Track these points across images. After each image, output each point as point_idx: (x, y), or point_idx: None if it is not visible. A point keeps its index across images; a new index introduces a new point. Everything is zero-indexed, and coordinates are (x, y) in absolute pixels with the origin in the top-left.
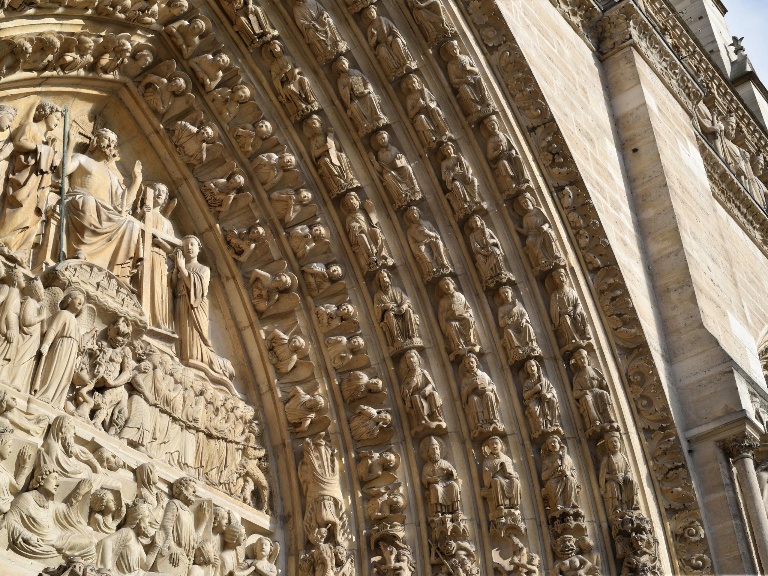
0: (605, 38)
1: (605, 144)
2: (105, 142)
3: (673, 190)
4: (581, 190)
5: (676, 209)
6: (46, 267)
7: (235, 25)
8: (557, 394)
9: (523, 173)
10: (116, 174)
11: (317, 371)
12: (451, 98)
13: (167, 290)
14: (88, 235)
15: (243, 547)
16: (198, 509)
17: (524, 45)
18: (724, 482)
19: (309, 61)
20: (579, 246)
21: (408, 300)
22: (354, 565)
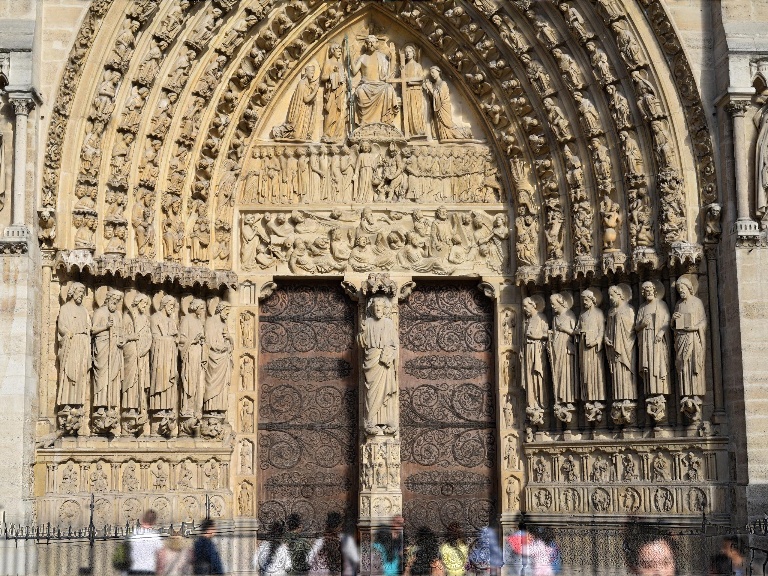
0: None
1: None
2: (370, 44)
3: None
4: None
5: None
6: None
7: None
8: (630, 100)
9: None
10: (388, 50)
11: (511, 119)
12: None
13: (423, 107)
14: (364, 110)
15: (490, 223)
16: (452, 219)
17: None
18: (725, 135)
19: None
20: None
21: (540, 68)
22: (539, 222)
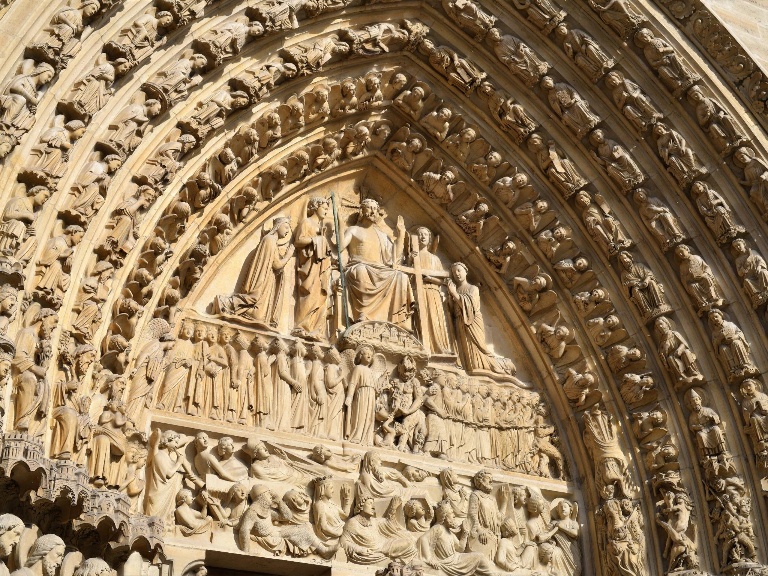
0: None
1: None
2: (369, 211)
3: None
4: None
5: None
6: (339, 334)
7: (449, 80)
8: None
9: (734, 131)
10: (386, 230)
11: (585, 351)
12: (654, 80)
13: (444, 317)
14: (366, 299)
15: (547, 512)
16: (498, 493)
17: (716, 5)
18: None
19: (520, 88)
20: None
21: (650, 273)
22: (641, 512)
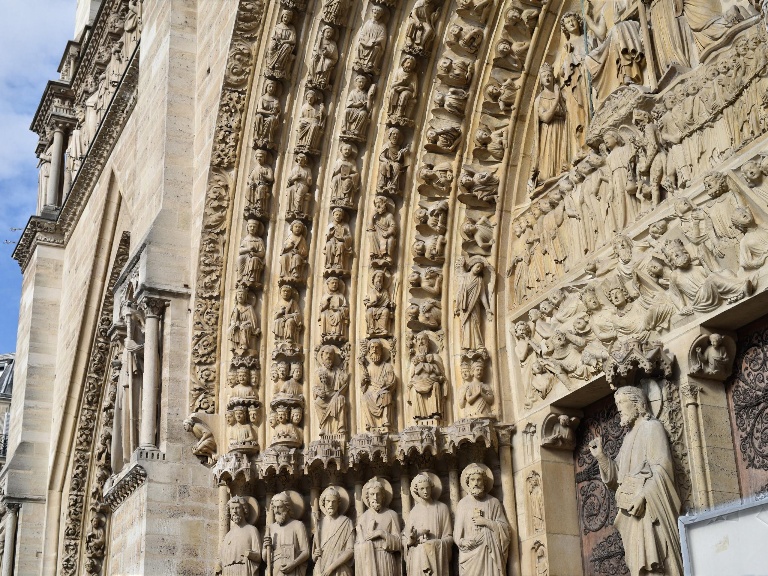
0: None
1: None
2: None
3: None
4: None
5: None
6: None
7: None
8: None
9: None
10: None
11: None
12: None
13: (671, 23)
14: (596, 85)
15: None
16: None
17: None
18: None
19: None
20: None
21: None
22: None
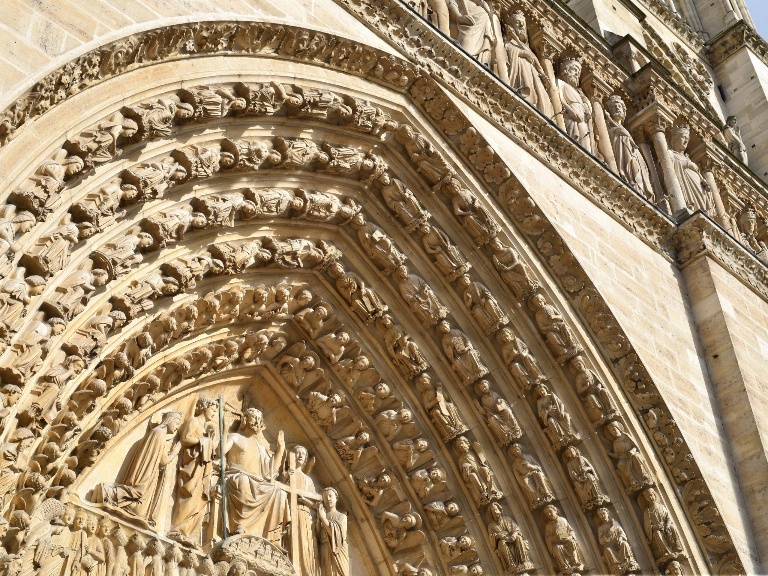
0: (682, 248)
1: (687, 356)
2: (253, 420)
3: (752, 393)
4: (664, 411)
5: (756, 412)
6: (214, 544)
7: (352, 306)
8: None
9: (609, 404)
10: (264, 442)
11: None
12: (541, 343)
13: None
14: (245, 510)
15: None
16: None
17: (602, 286)
18: None
19: (416, 326)
20: (666, 462)
21: (518, 528)
22: None
